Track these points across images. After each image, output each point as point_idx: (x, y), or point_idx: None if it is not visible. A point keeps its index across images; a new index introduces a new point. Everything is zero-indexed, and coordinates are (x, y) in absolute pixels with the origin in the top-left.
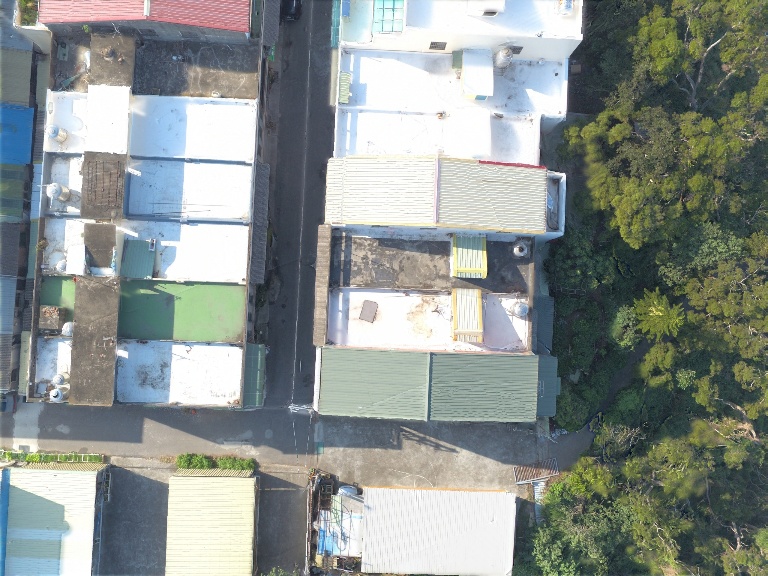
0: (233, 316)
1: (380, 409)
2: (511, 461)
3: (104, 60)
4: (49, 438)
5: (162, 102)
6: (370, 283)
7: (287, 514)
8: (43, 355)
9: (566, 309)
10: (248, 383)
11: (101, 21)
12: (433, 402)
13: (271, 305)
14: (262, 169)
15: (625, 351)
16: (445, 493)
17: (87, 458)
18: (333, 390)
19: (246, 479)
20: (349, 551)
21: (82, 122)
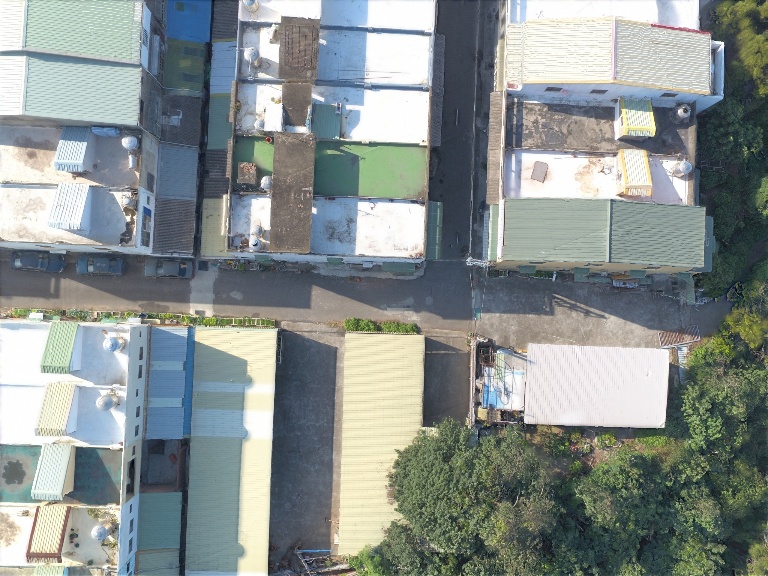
0: (414, 175)
1: (562, 253)
2: (656, 327)
3: None
4: (223, 304)
5: None
6: (541, 145)
7: (447, 376)
8: (237, 211)
9: (710, 182)
10: (429, 237)
11: None
12: (613, 245)
13: (430, 180)
14: (438, 39)
15: (764, 222)
16: (603, 349)
17: (260, 322)
18: (517, 237)
19: (416, 336)
20: (512, 405)
21: None
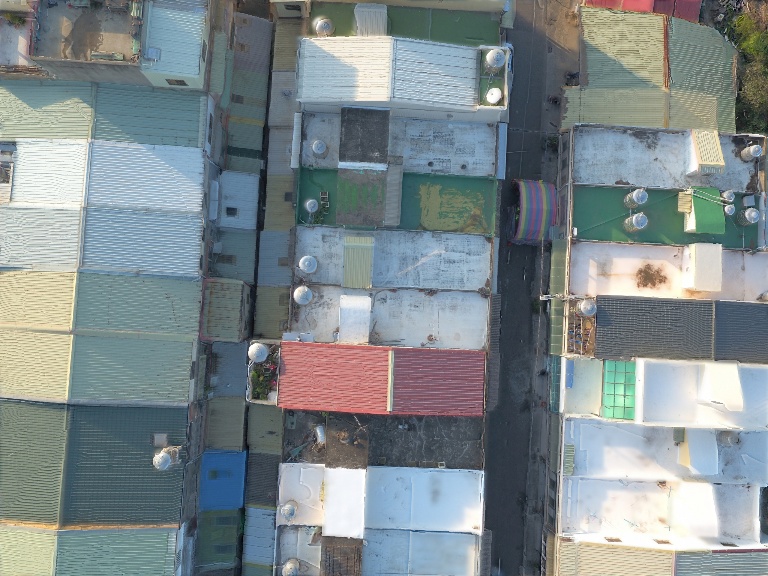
0: None
1: None
2: None
3: (340, 442)
4: None
5: (388, 470)
6: None
7: None
8: None
9: None
10: None
11: (342, 411)
12: None
13: None
14: (485, 536)
15: None
16: None
17: None
18: None
19: None
20: None
21: (309, 491)
